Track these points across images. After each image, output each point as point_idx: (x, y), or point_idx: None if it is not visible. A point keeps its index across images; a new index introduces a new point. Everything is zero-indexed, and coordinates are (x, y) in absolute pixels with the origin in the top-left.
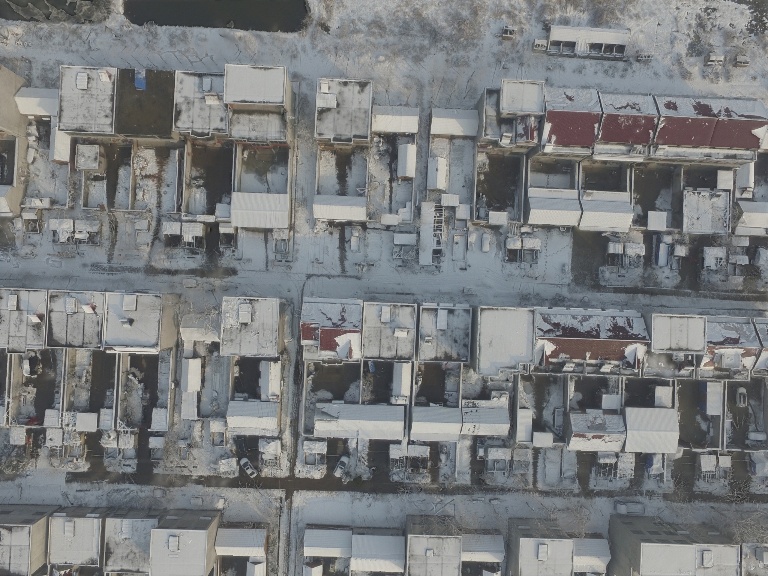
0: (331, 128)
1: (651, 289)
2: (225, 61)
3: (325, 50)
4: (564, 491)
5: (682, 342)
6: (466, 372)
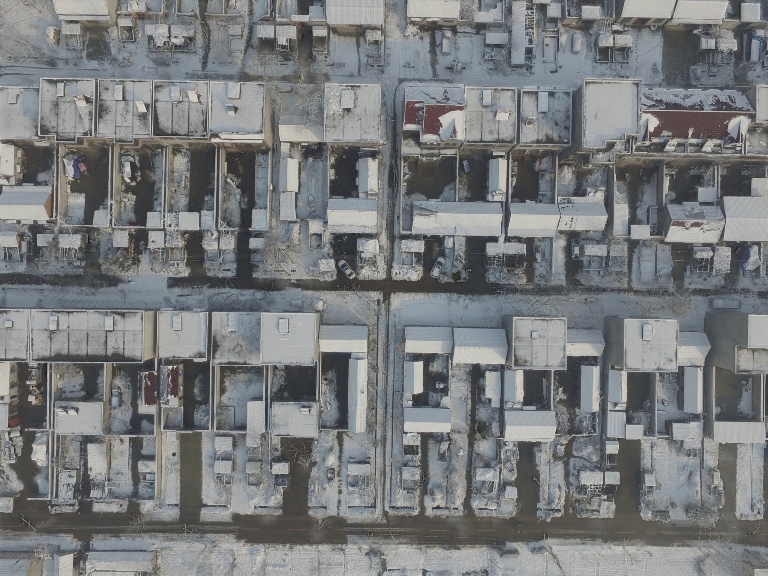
0: None
1: (742, 88)
2: None
3: None
4: (659, 290)
5: None
6: (559, 173)
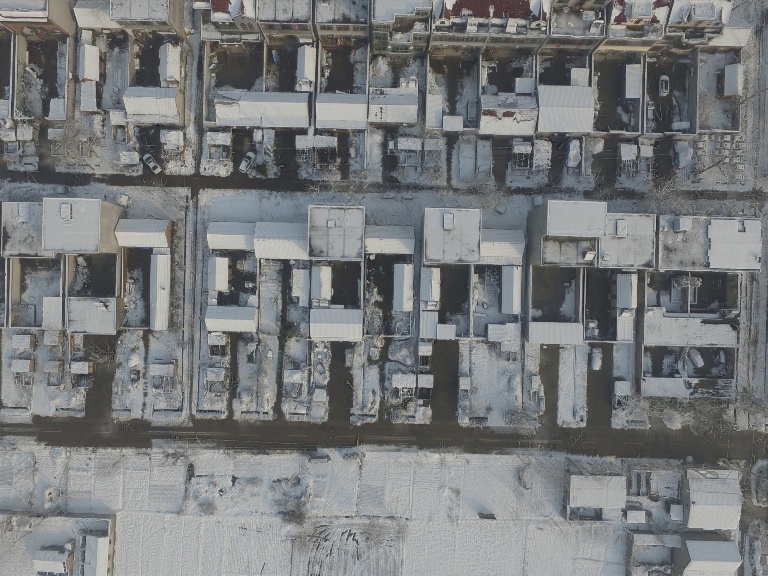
0: None
1: None
2: None
3: None
4: (480, 188)
5: None
6: (375, 65)
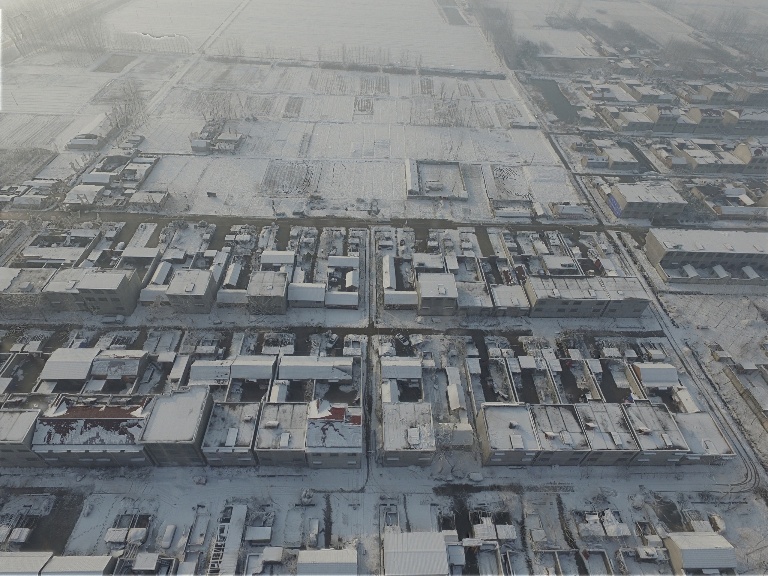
0: None
1: None
2: None
3: None
4: (161, 330)
5: (6, 418)
6: None
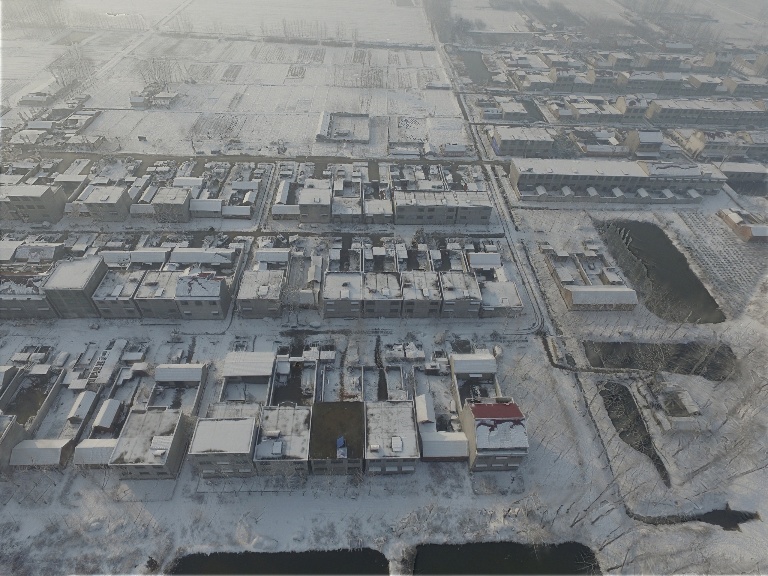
0: (165, 418)
1: None
2: (274, 510)
3: (159, 532)
4: (81, 233)
5: None
6: None
